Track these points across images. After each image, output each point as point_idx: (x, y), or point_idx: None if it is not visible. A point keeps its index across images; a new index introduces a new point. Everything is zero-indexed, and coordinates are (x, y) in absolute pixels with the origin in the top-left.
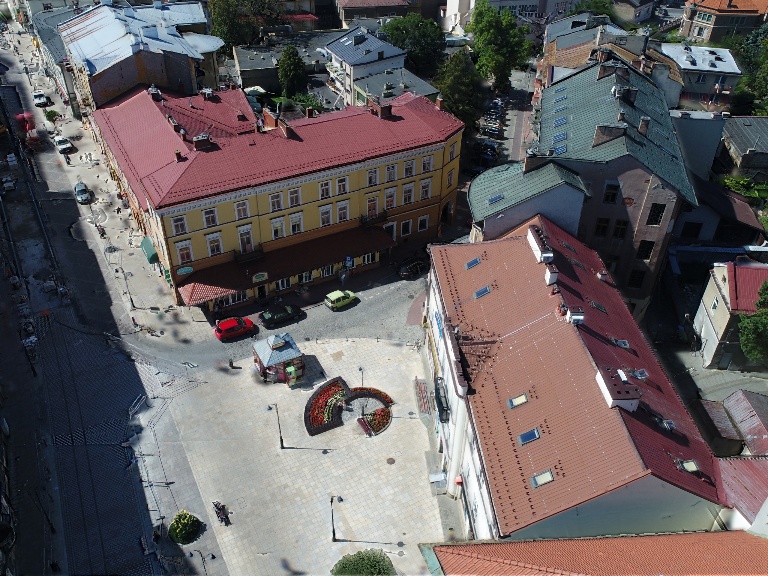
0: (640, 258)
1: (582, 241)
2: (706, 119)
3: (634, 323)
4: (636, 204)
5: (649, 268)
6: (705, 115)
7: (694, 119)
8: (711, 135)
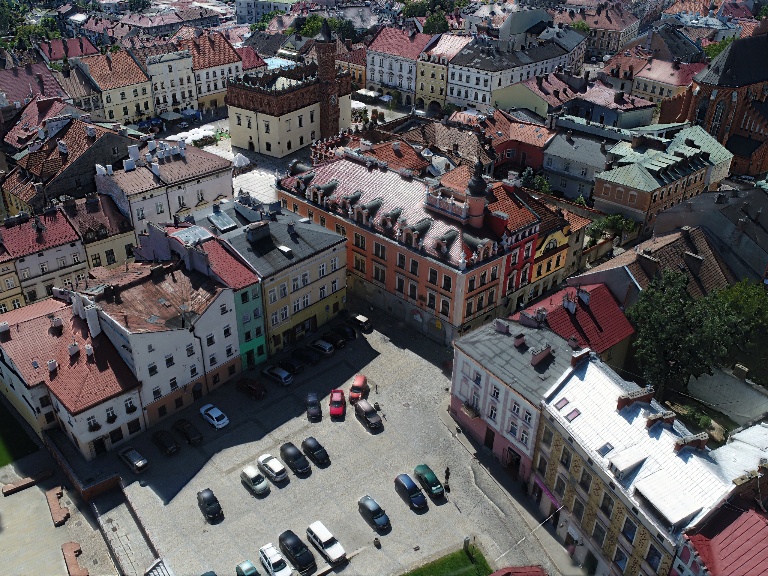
0: None
1: (752, 13)
2: None
3: (741, 17)
4: None
5: None
6: None
7: None
8: None
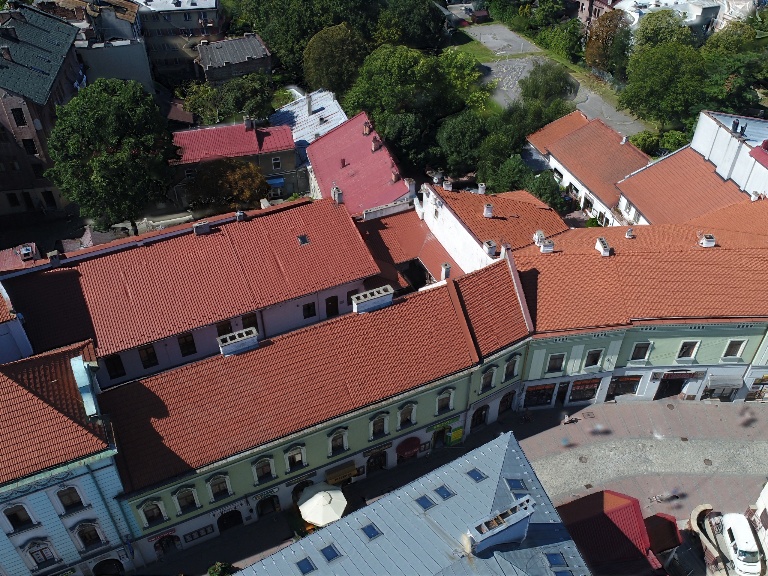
0: (31, 154)
1: None
2: (126, 45)
3: None
4: (0, 112)
5: (42, 160)
6: (128, 42)
7: (116, 46)
8: (137, 57)
